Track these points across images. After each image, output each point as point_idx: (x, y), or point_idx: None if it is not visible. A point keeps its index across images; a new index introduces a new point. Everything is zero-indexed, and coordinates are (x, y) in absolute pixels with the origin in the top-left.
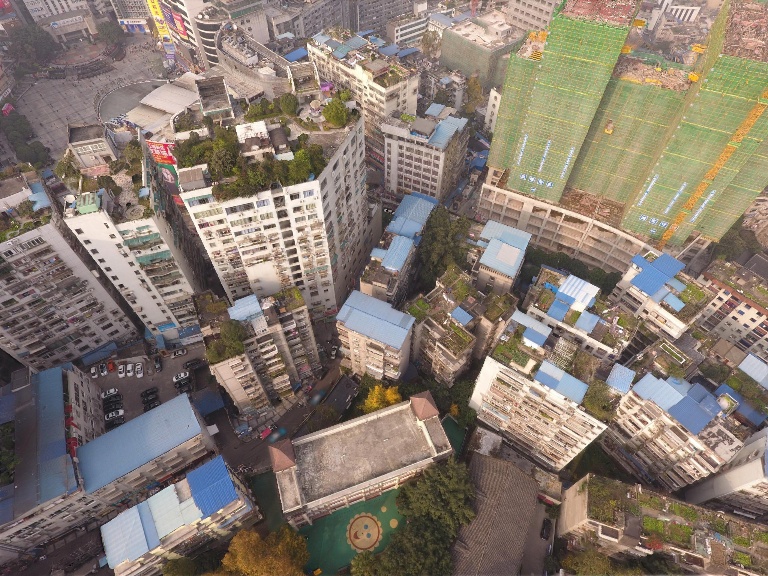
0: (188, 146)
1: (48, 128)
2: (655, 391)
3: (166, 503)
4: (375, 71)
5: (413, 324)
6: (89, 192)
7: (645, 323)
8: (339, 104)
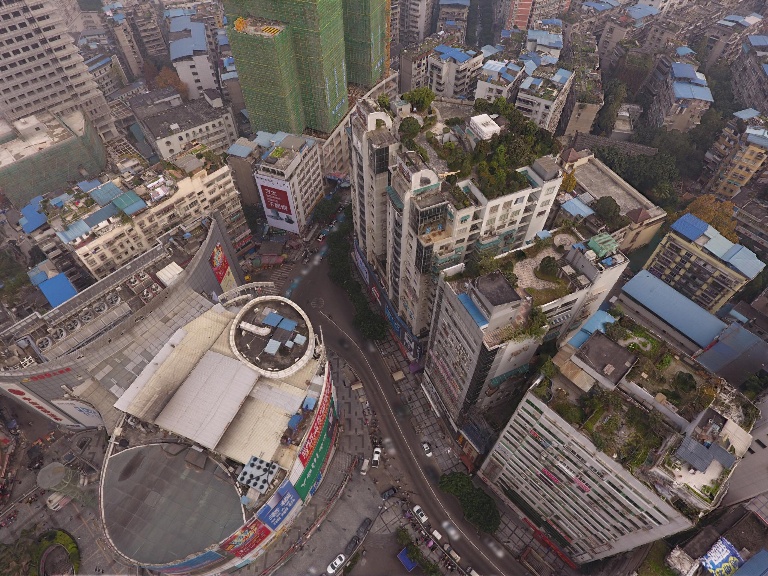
0: None
1: None
2: (530, 69)
3: (716, 246)
4: None
5: None
6: (587, 252)
7: (471, 76)
8: None
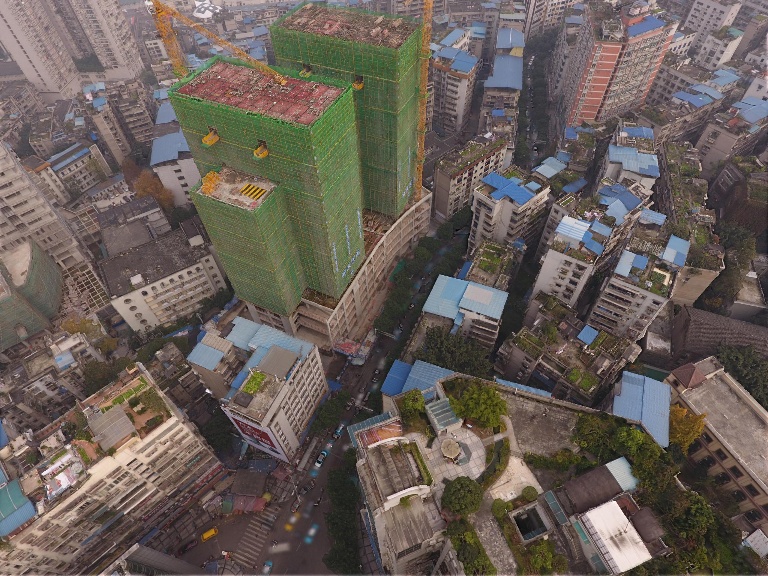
0: None
1: None
2: (617, 213)
3: None
4: (134, 429)
5: (601, 386)
6: None
7: (531, 214)
8: (479, 395)
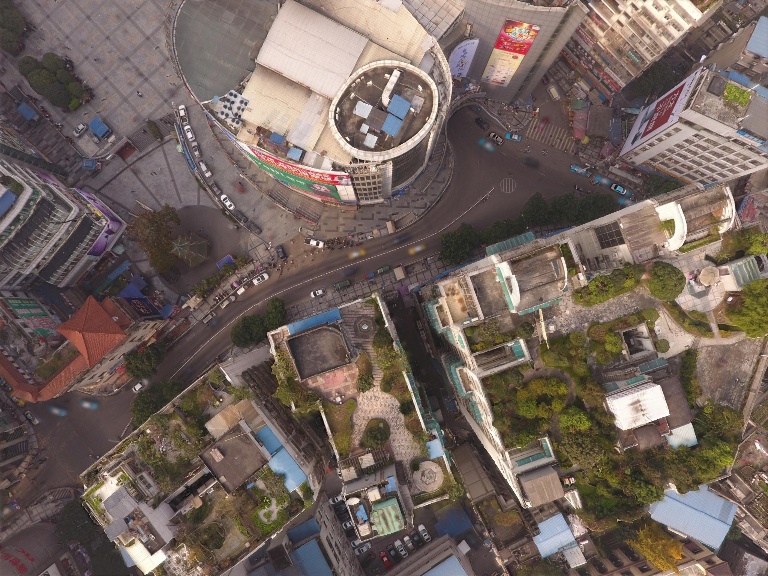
0: (506, 393)
1: (42, 4)
2: None
3: None
4: None
5: None
6: (377, 490)
7: None
8: None
